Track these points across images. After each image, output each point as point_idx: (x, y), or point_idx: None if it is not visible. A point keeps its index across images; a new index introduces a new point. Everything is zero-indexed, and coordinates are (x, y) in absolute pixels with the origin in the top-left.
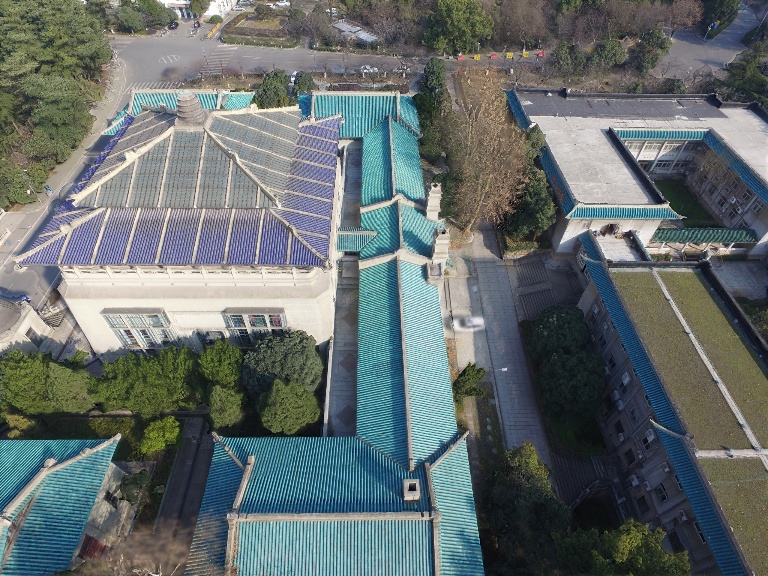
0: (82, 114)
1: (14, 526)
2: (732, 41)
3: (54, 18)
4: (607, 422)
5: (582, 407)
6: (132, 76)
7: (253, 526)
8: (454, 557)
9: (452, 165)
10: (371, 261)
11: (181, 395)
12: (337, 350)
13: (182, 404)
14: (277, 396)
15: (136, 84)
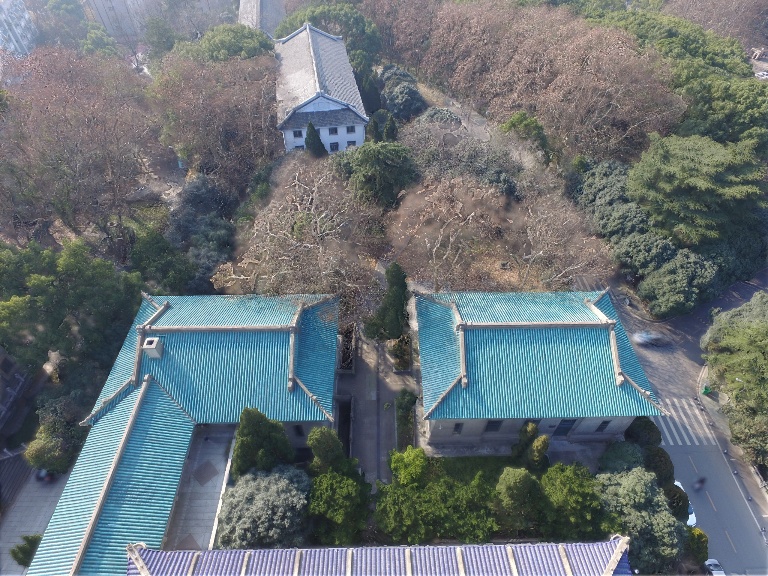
0: None
1: None
2: None
3: None
4: None
5: None
6: None
7: None
8: None
9: None
10: None
11: None
12: None
13: None
14: None
15: None
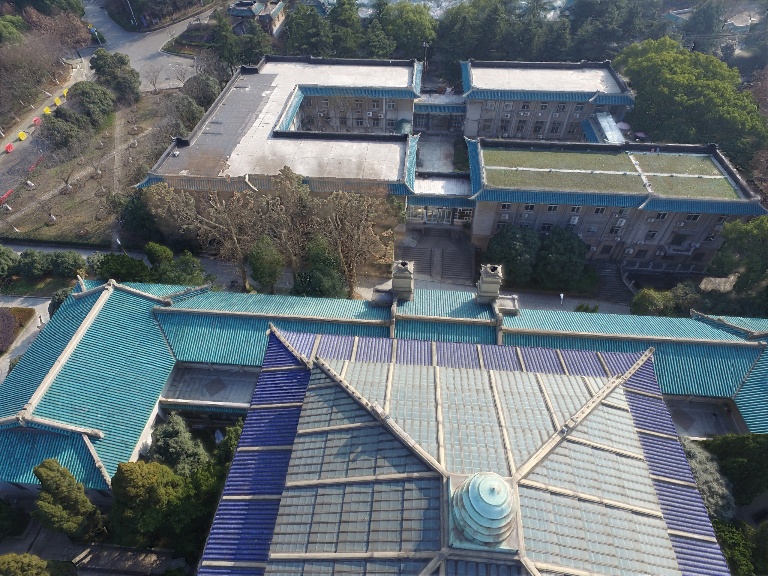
0: None
1: None
2: (122, 35)
3: None
4: None
5: None
6: None
7: None
8: None
9: (272, 270)
10: None
11: None
12: None
13: None
14: None
15: None
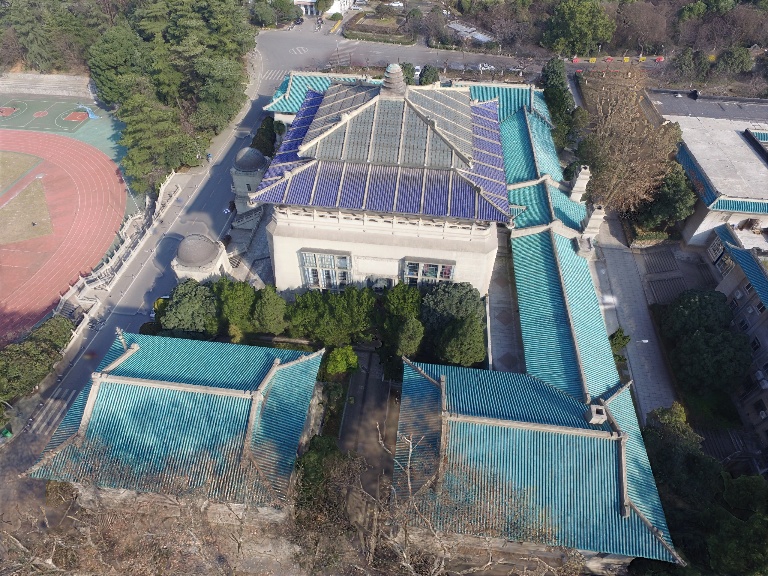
0: (240, 93)
1: (262, 403)
2: None
3: (221, 8)
4: (744, 402)
5: (725, 382)
6: (268, 64)
7: (461, 425)
8: (633, 477)
9: (584, 156)
10: (524, 231)
11: (362, 327)
12: (492, 306)
13: (361, 335)
14: (469, 327)
15: (272, 71)
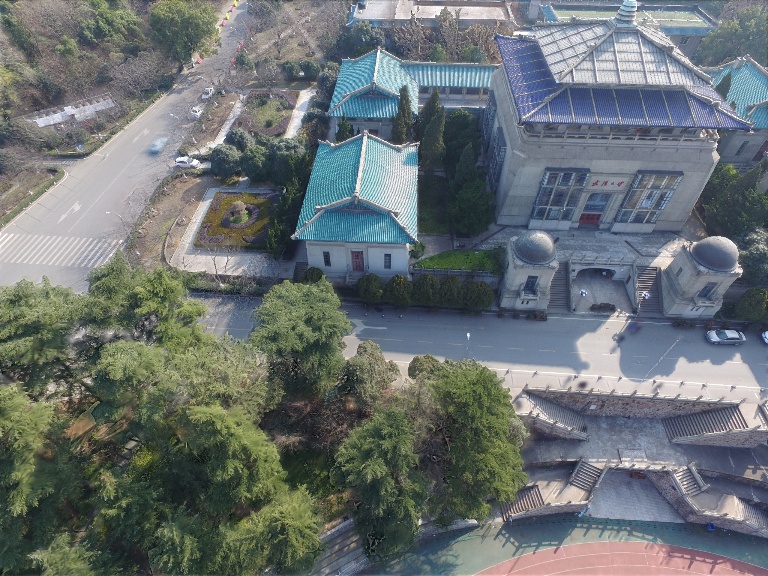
0: None
1: None
2: None
3: (81, 298)
4: None
5: None
6: None
7: None
8: None
9: None
10: None
11: None
12: None
13: None
14: None
15: None
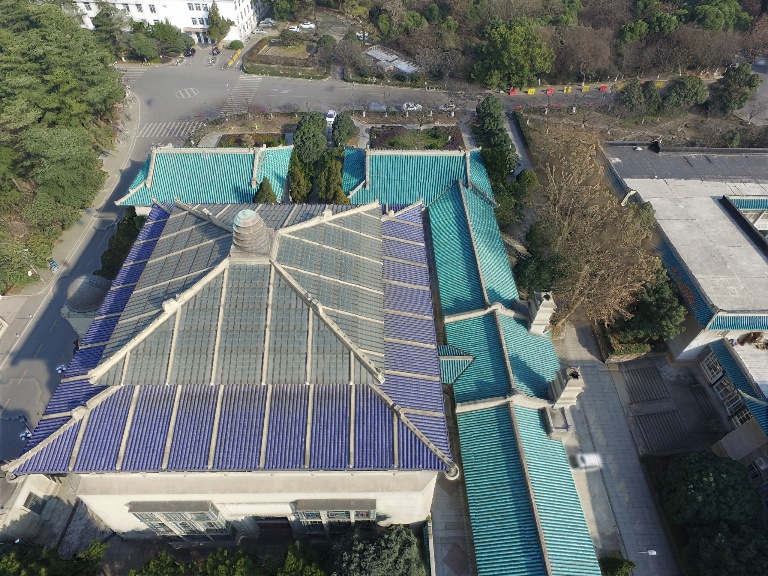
0: (93, 172)
1: None
2: None
3: (60, 58)
4: None
5: None
6: (147, 114)
7: None
8: None
9: (538, 243)
10: (473, 405)
11: None
12: (437, 537)
13: None
14: None
15: (151, 124)
